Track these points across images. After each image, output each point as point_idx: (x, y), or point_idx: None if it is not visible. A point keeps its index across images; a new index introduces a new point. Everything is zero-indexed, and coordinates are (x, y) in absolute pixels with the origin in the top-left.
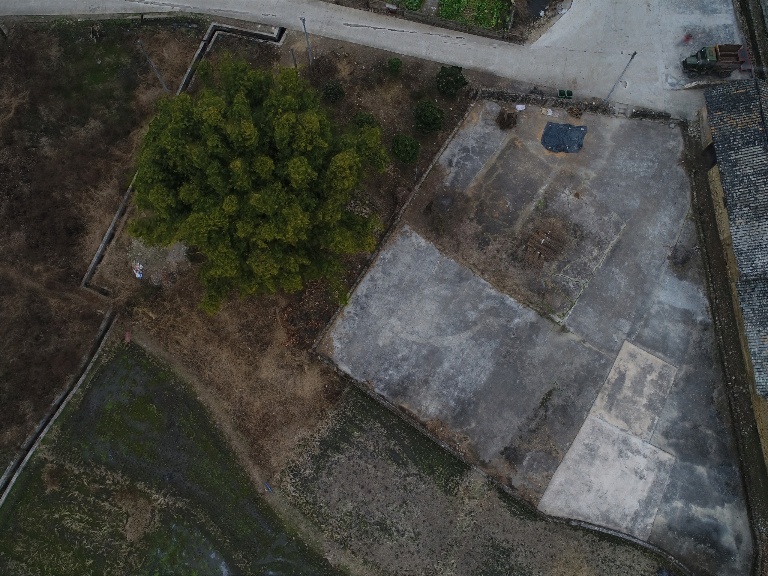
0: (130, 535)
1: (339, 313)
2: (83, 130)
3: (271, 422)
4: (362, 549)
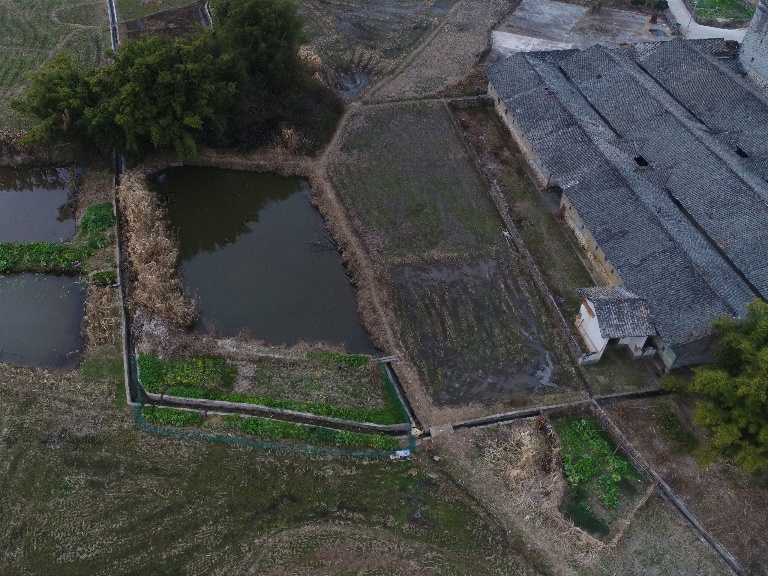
0: None
1: None
2: None
3: None
4: (462, 8)
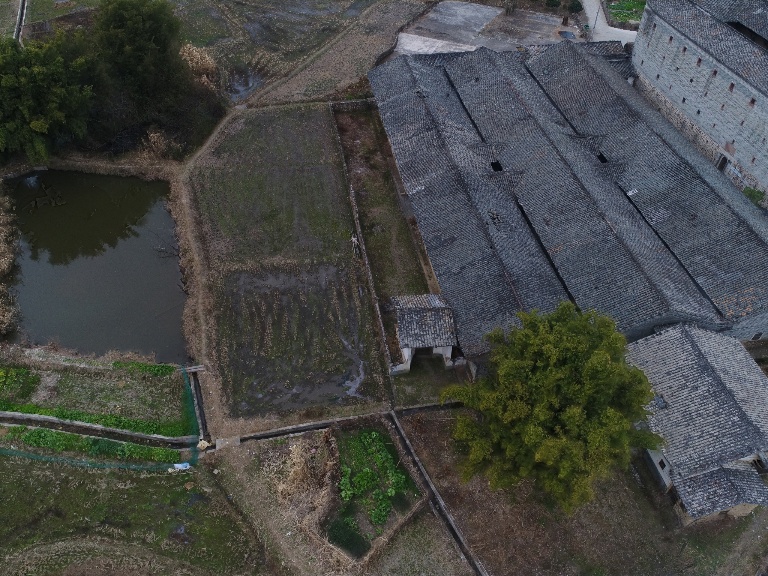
0: None
1: (462, 1)
2: None
3: None
4: None
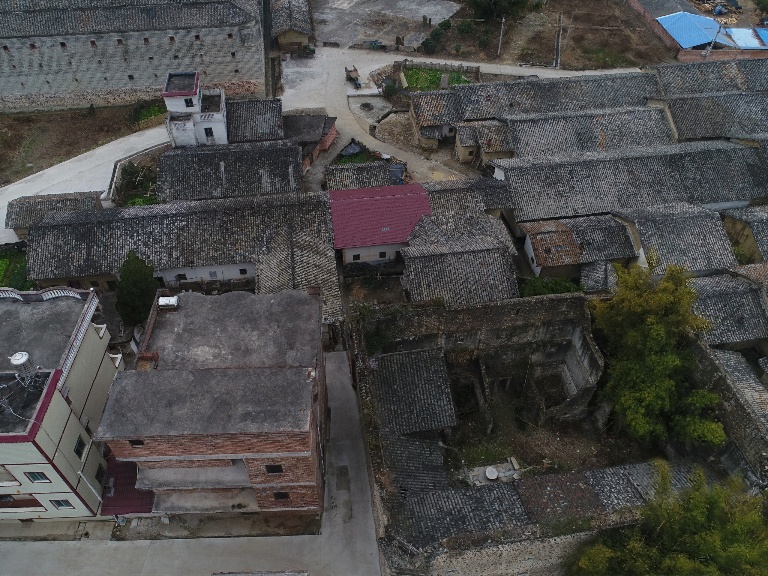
0: None
1: None
2: (594, 37)
3: None
4: None
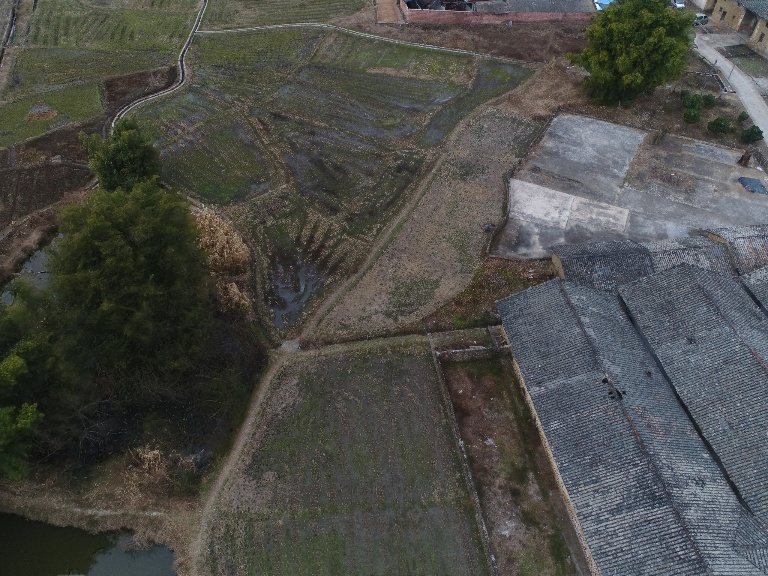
0: (452, 78)
1: (583, 116)
2: None
3: (517, 103)
4: None
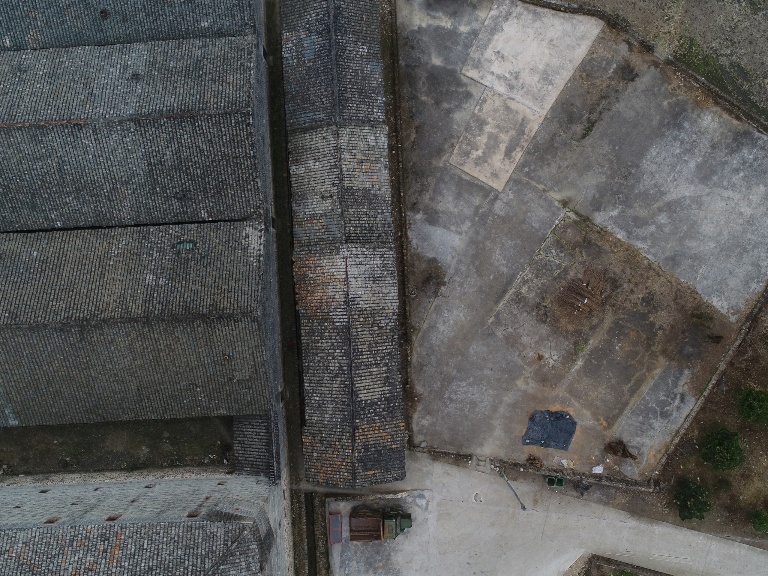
0: None
1: None
2: None
3: None
4: None
